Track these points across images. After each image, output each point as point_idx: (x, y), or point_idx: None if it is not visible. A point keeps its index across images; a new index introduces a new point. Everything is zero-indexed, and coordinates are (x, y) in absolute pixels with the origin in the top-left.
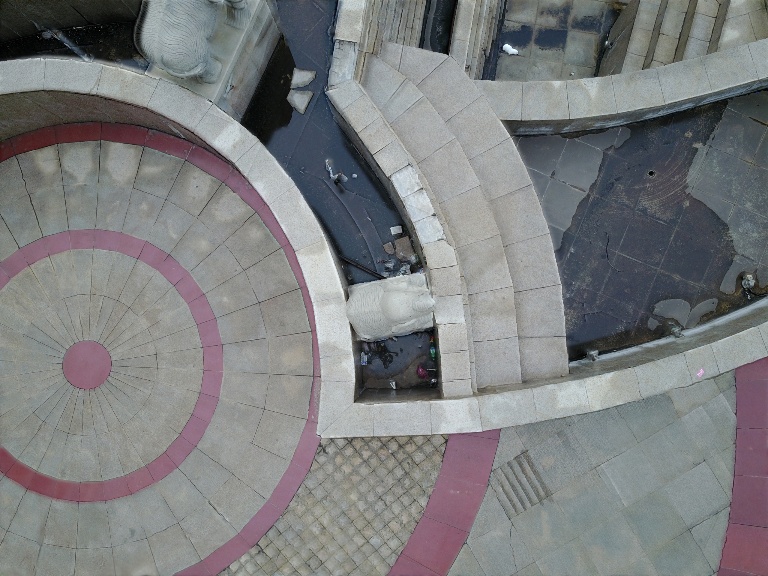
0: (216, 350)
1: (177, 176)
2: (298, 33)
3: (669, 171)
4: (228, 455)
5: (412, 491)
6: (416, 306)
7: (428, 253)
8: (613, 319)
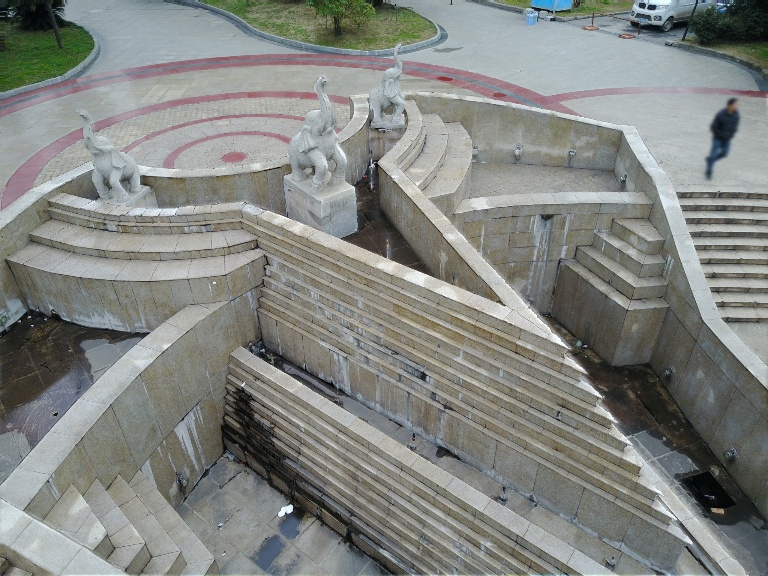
0: None
1: None
2: None
3: (43, 425)
4: None
5: None
6: None
7: (127, 207)
8: (6, 353)
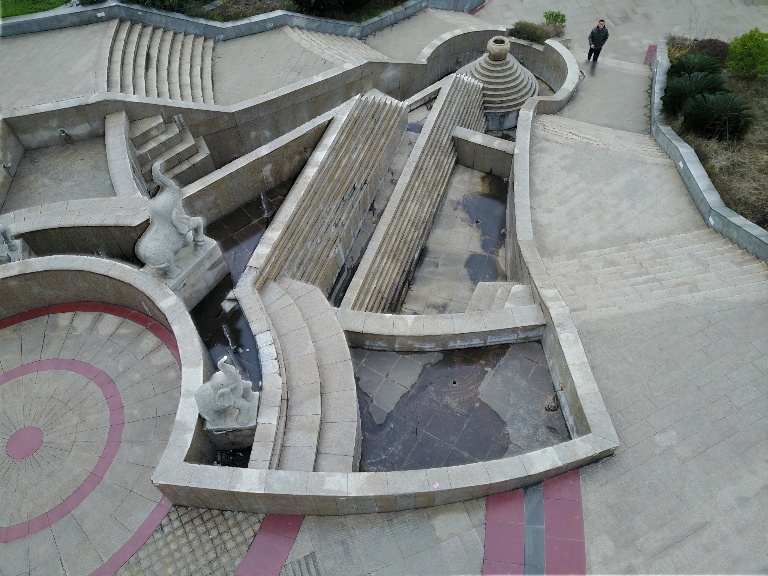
0: (115, 444)
1: (138, 336)
2: (240, 273)
3: (467, 383)
4: (91, 522)
5: (217, 572)
6: None
7: (265, 379)
8: None
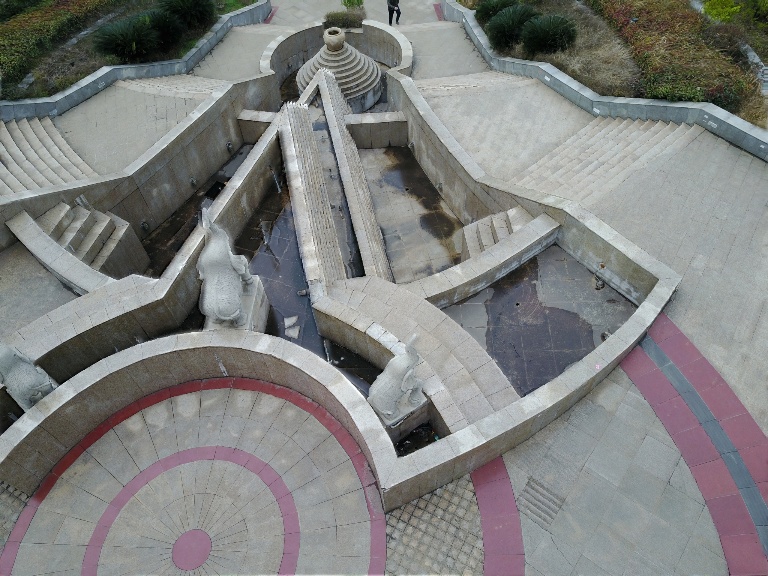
0: (287, 498)
1: (228, 399)
2: (280, 301)
3: (526, 299)
4: (321, 573)
5: (468, 540)
6: (408, 343)
7: None
8: None
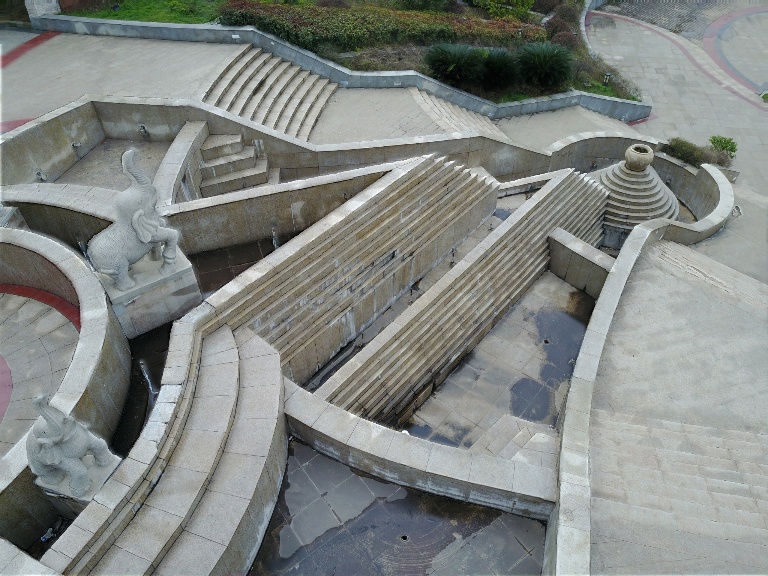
0: None
1: (69, 345)
2: None
3: (421, 544)
4: None
5: None
6: None
7: (137, 445)
8: None
